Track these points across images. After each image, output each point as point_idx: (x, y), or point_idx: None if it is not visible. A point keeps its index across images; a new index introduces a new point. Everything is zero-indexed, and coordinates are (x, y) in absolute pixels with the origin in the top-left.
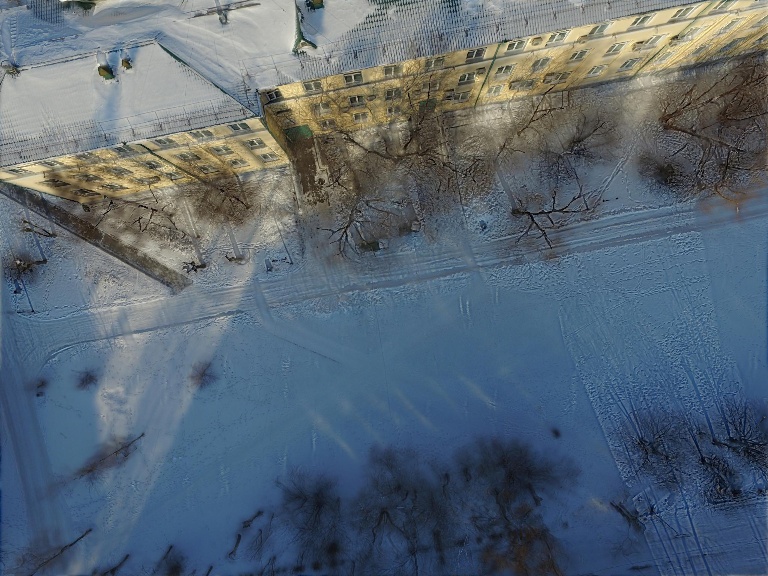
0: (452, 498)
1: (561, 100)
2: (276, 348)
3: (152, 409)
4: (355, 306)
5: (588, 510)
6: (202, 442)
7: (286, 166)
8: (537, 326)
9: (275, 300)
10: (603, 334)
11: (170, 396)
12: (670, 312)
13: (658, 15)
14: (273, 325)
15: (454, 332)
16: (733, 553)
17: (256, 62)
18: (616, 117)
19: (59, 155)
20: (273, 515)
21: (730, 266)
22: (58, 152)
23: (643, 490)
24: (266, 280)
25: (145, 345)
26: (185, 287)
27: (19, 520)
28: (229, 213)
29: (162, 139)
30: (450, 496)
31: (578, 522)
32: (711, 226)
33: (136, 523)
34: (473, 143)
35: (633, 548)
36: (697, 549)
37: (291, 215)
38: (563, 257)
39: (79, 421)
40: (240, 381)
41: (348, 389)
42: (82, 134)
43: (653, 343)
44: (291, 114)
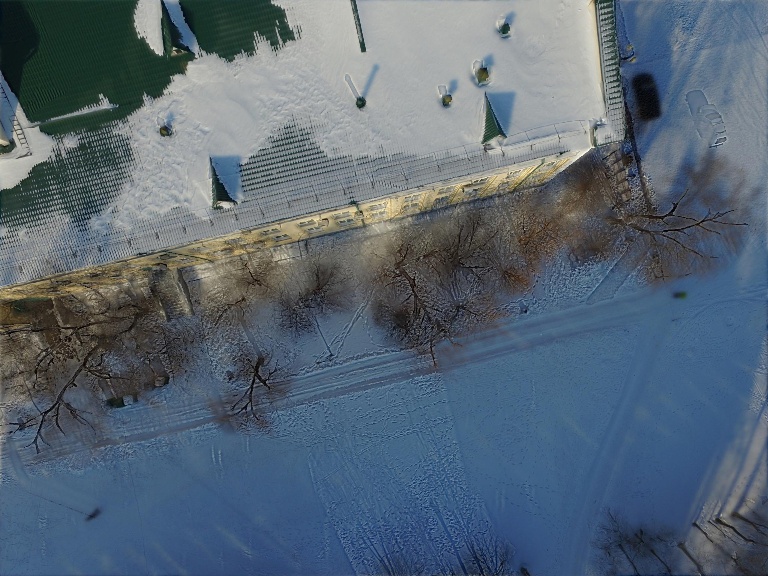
0: None
1: (298, 250)
2: (33, 506)
3: None
4: (107, 461)
5: None
6: None
7: None
8: (288, 473)
9: (30, 457)
10: (352, 479)
11: None
12: (416, 454)
13: None
14: (29, 483)
15: (207, 483)
16: None
17: None
18: (355, 263)
19: None
20: None
21: (472, 406)
22: None
23: None
24: (20, 438)
25: None
26: None
27: None
28: None
29: None
30: None
31: None
32: (452, 367)
33: None
34: (217, 294)
35: None
36: None
37: (40, 373)
38: (309, 404)
39: None
40: None
41: (105, 544)
42: None
43: (401, 486)
44: None
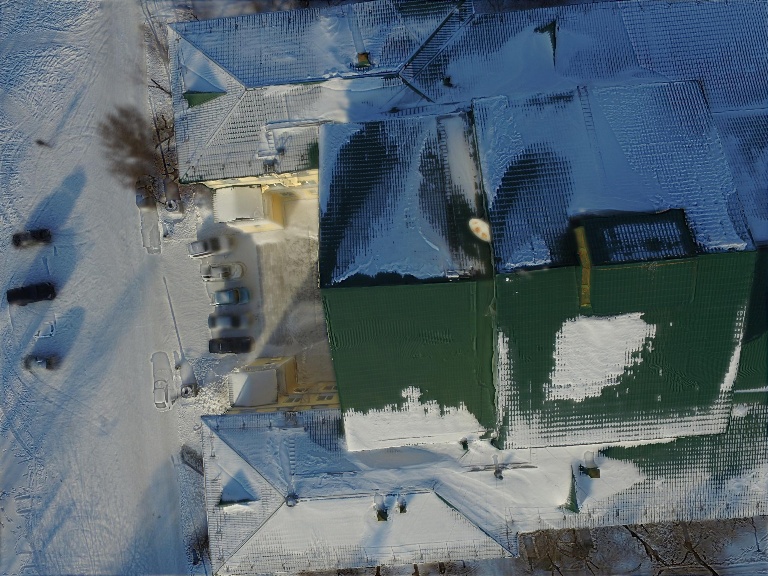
0: None
1: None
2: None
3: None
4: None
5: None
6: None
7: None
8: None
9: None
10: None
11: None
12: None
13: None
14: None
15: None
16: None
17: (522, 511)
18: None
19: None
20: None
21: None
22: (320, 567)
23: None
24: None
25: None
26: (358, 575)
27: None
28: None
29: None
30: None
31: None
32: None
33: None
34: None
35: None
36: None
37: None
38: None
39: None
40: None
41: None
42: (345, 555)
43: None
44: None
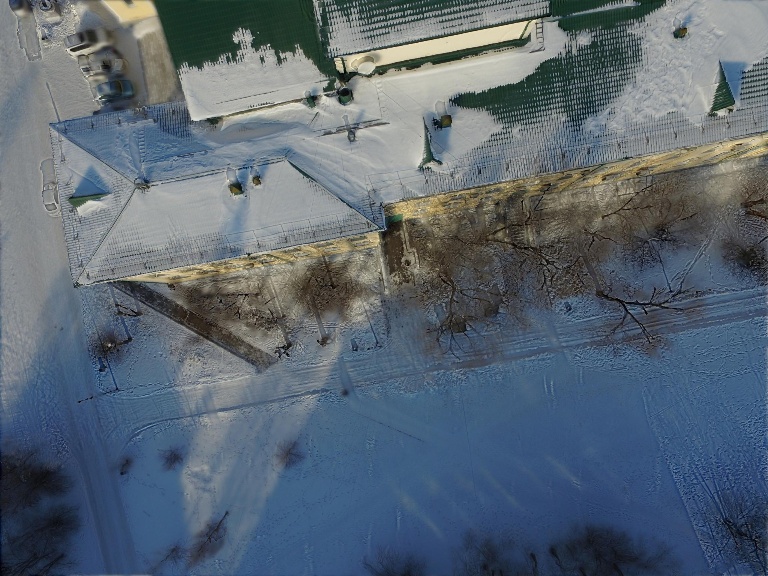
0: None
1: (645, 185)
2: (361, 427)
3: (236, 487)
4: (441, 386)
5: None
6: (286, 521)
7: (372, 247)
8: (621, 406)
9: (360, 379)
10: (687, 415)
11: (254, 474)
12: (753, 393)
13: None
14: (358, 404)
15: (539, 412)
16: None
17: (382, 177)
18: (698, 201)
19: (184, 266)
20: None
21: None
22: (183, 263)
23: (727, 570)
24: (351, 359)
25: (229, 423)
26: (270, 365)
27: None
28: (315, 293)
29: None
30: None
31: None
32: None
33: None
34: (557, 225)
35: None
36: None
37: (377, 295)
38: None
39: (162, 499)
40: (325, 460)
41: (433, 468)
42: (208, 246)
43: (736, 424)
44: (393, 209)
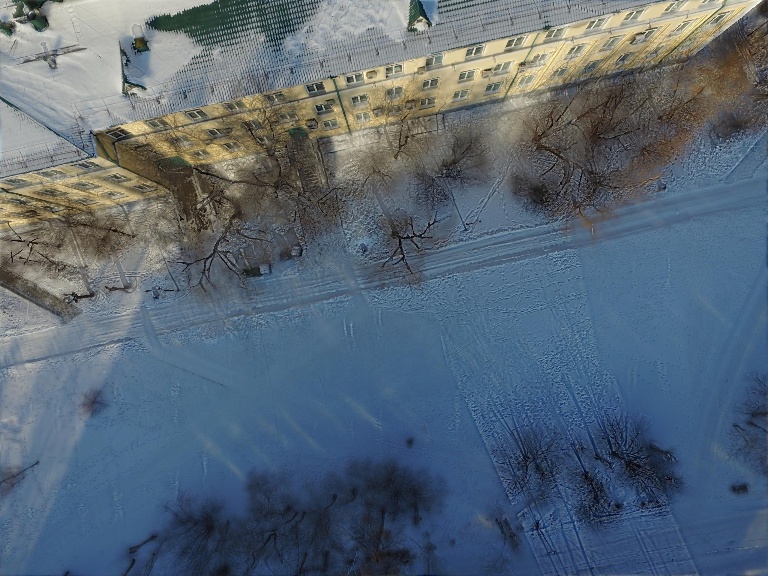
0: (339, 519)
1: (436, 123)
2: (165, 374)
3: (46, 437)
4: (240, 331)
5: (474, 527)
6: (95, 469)
7: (169, 195)
8: (419, 346)
9: (163, 327)
10: (484, 353)
11: (63, 424)
12: (549, 329)
13: (489, 46)
14: (162, 351)
15: (338, 354)
16: (620, 566)
17: (88, 104)
18: (491, 138)
19: None
20: (165, 539)
21: (607, 282)
22: None
23: (528, 506)
24: (154, 307)
25: (37, 374)
26: (75, 316)
27: None
28: (115, 242)
29: (13, 179)
30: (337, 517)
31: (465, 539)
32: (587, 243)
33: (33, 550)
34: (352, 167)
35: (504, 566)
36: (585, 563)
37: (175, 243)
38: (443, 278)
39: None
40: (131, 407)
41: (237, 413)
42: None
43: (533, 360)
44: (153, 148)
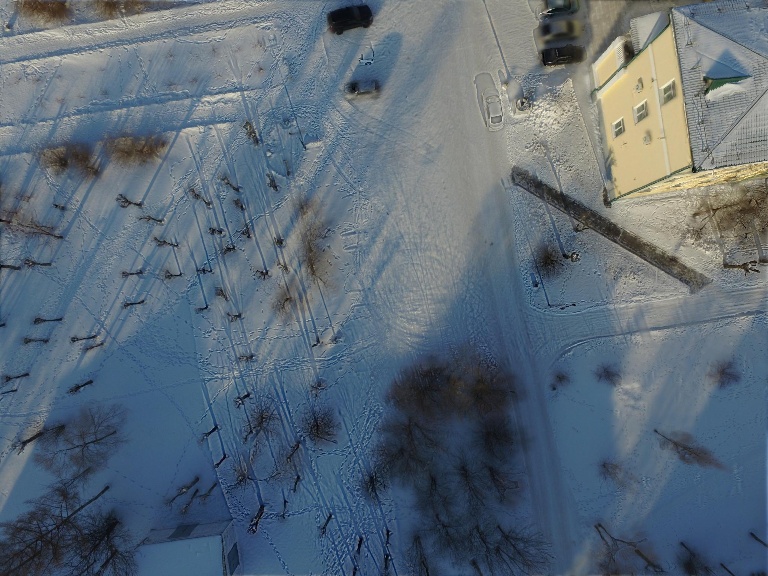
0: None
1: None
2: None
3: (666, 406)
4: None
5: None
6: (716, 440)
7: None
8: None
9: None
10: None
11: (685, 394)
12: None
13: None
14: None
15: None
16: None
17: None
18: None
19: None
20: None
21: None
22: None
23: None
24: None
25: (661, 342)
26: (704, 286)
27: (525, 513)
28: (756, 214)
29: None
30: None
31: None
32: None
33: (645, 519)
34: None
35: None
36: None
37: None
38: None
39: (592, 416)
40: (758, 381)
41: None
42: None
43: None
44: None
